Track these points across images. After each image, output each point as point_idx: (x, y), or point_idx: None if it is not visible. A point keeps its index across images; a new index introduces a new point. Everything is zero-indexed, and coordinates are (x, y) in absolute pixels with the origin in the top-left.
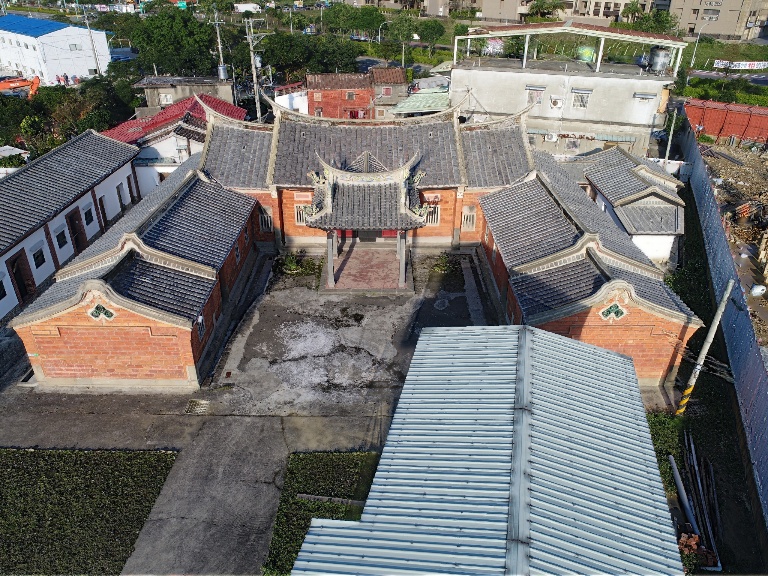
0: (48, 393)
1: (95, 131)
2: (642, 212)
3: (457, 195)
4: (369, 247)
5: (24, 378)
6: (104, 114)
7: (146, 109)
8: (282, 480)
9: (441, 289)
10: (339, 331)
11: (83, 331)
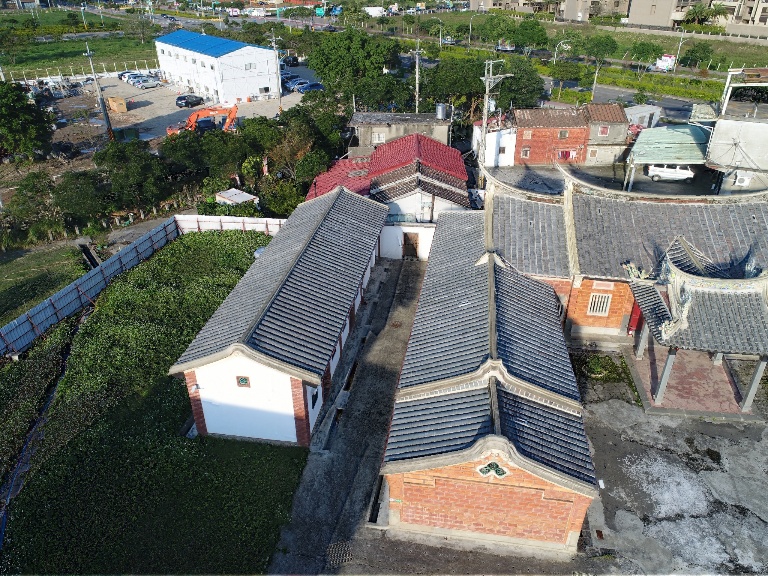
0: (404, 542)
1: (346, 188)
2: None
3: None
4: None
5: (370, 516)
6: (323, 156)
7: (359, 149)
8: None
9: None
10: (702, 477)
11: (462, 485)
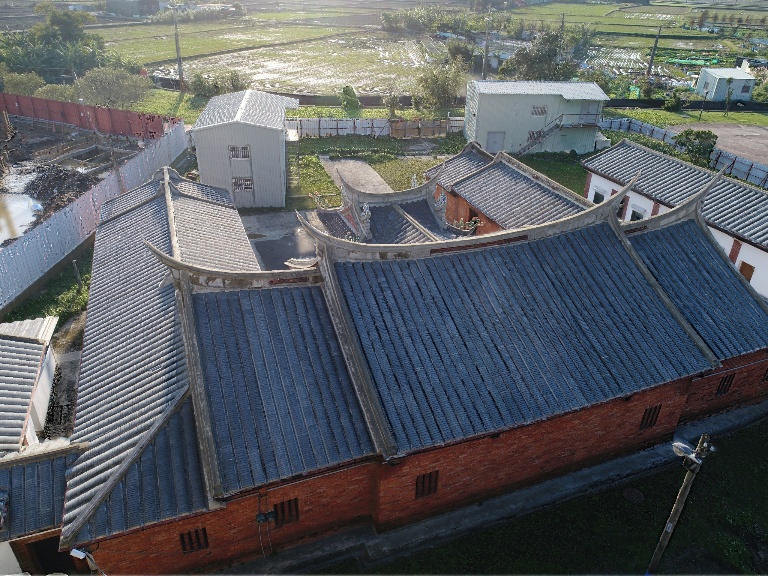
0: None
1: None
2: None
3: None
4: None
5: None
6: None
7: None
8: None
9: None
10: None
11: None
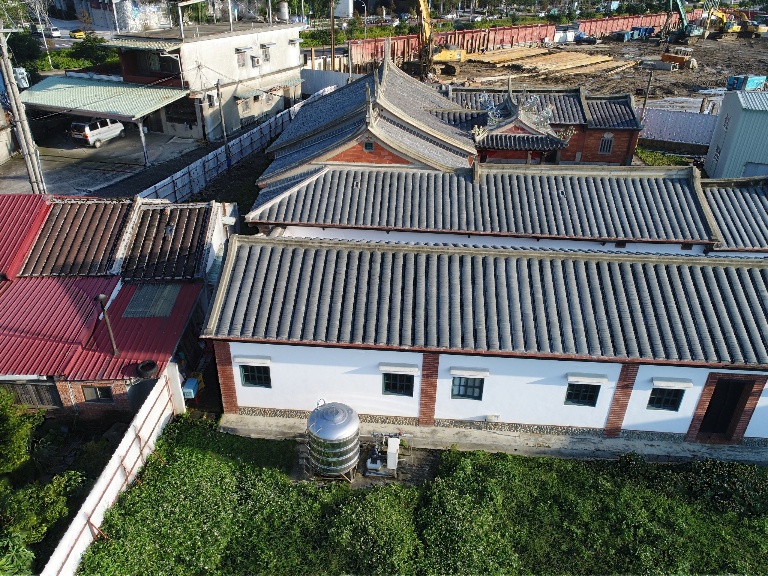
0: None
1: None
2: None
3: None
4: None
5: None
6: None
7: None
8: None
9: None
10: None
11: None
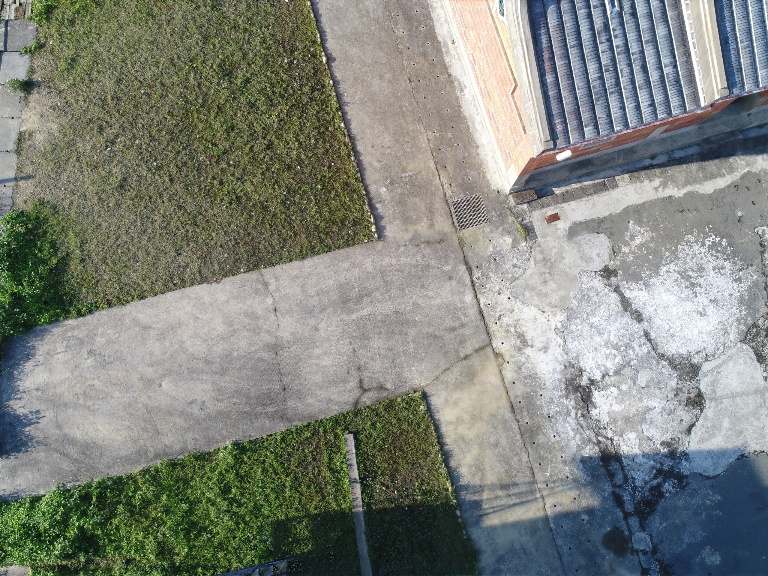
0: None
1: None
2: None
3: None
4: None
5: None
6: None
7: None
8: (372, 401)
9: None
10: (737, 348)
11: None
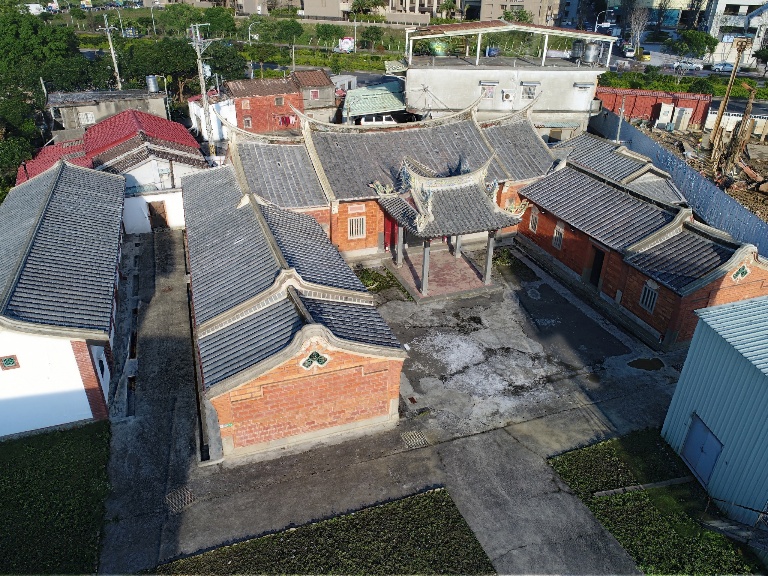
0: (244, 465)
1: (68, 162)
2: (645, 187)
3: (503, 190)
4: (421, 251)
5: (200, 456)
6: (23, 141)
7: (66, 132)
8: (565, 485)
9: (520, 280)
10: (473, 336)
11: (289, 385)
